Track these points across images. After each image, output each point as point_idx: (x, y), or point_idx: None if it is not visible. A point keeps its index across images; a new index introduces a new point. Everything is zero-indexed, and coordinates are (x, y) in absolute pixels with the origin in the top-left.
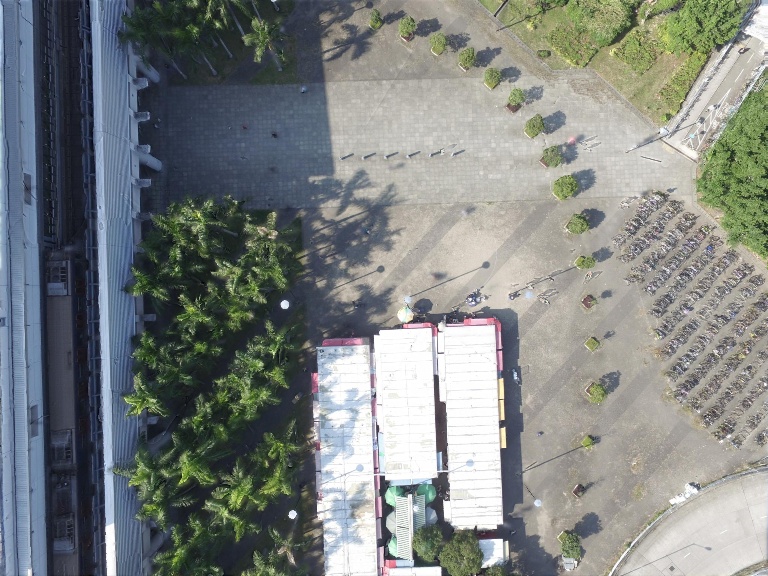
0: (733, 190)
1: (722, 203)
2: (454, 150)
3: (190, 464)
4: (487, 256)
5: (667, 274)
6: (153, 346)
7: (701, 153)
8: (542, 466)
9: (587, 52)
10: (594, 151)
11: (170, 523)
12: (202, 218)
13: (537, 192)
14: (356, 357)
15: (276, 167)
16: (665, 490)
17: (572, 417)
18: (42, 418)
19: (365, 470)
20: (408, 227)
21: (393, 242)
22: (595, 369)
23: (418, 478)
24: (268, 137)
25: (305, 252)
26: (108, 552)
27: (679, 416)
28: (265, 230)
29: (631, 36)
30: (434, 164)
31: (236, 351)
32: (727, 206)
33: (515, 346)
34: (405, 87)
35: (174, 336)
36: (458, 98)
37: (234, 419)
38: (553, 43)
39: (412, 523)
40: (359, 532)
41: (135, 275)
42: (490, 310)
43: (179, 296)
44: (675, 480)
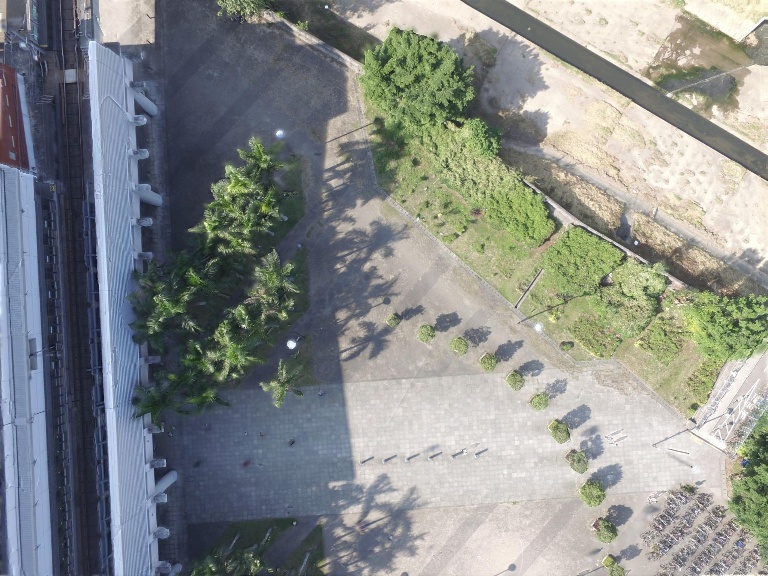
0: None
1: None
2: (477, 449)
3: None
4: (513, 558)
5: (697, 572)
6: None
7: (730, 446)
8: None
9: (611, 343)
10: (620, 445)
11: None
12: None
13: (563, 490)
14: None
15: (295, 473)
16: None
17: None
18: None
19: None
20: (431, 531)
21: (416, 547)
22: None
23: None
24: (286, 442)
25: (326, 560)
26: None
27: None
28: None
29: (656, 326)
30: (457, 465)
31: None
32: (760, 528)
33: None
34: (425, 385)
35: None
36: (480, 395)
37: None
38: (576, 335)
39: None
40: None
41: None
42: None
43: None
44: None
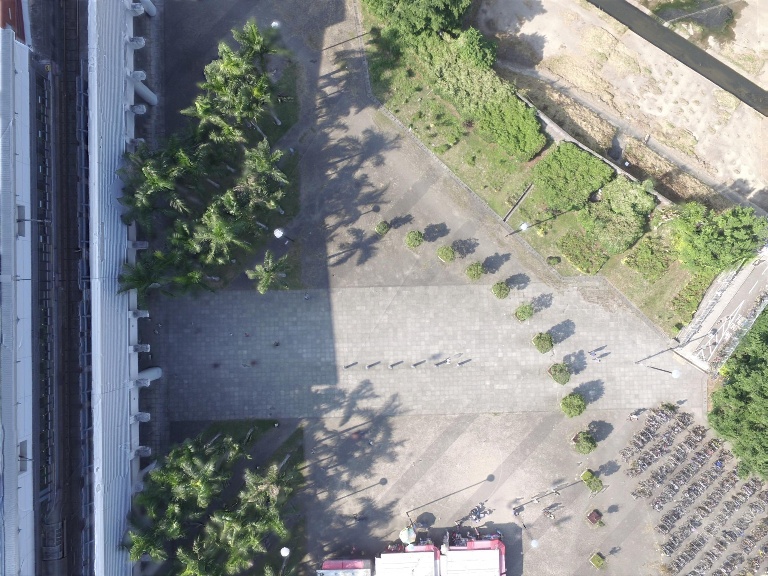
0: (746, 435)
1: (734, 437)
2: (460, 359)
3: None
4: (492, 469)
5: (675, 490)
6: None
7: (712, 366)
8: None
9: (598, 260)
10: (603, 361)
11: None
12: (201, 485)
13: (544, 403)
14: None
15: (278, 375)
16: None
17: None
18: None
19: None
20: (412, 438)
21: (396, 454)
22: None
23: None
24: (271, 344)
25: (306, 463)
26: None
27: None
28: (266, 486)
29: (643, 244)
30: (439, 374)
31: None
32: (739, 440)
33: (519, 561)
34: (411, 294)
35: None
36: (465, 306)
37: None
38: (563, 250)
39: None
40: None
41: None
42: (494, 524)
43: (177, 550)
44: None
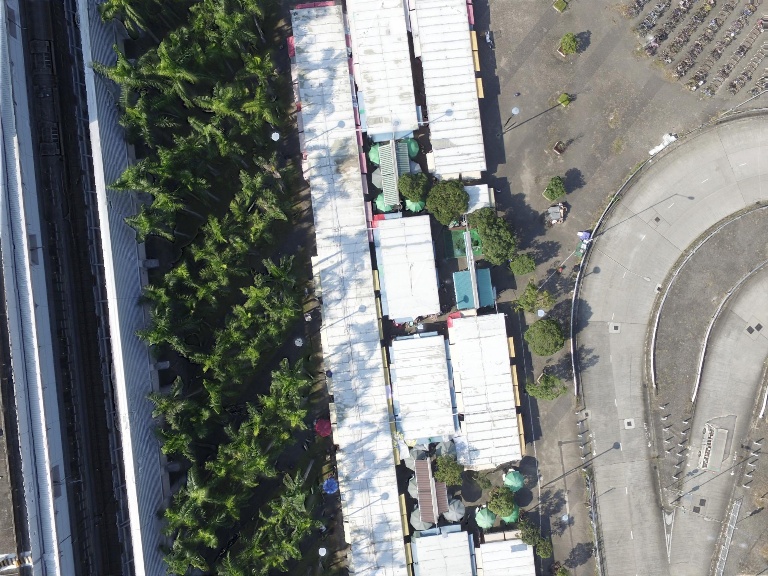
0: None
1: None
2: None
3: (168, 57)
4: None
5: None
6: None
7: None
8: (521, 126)
9: None
10: None
11: (154, 139)
12: None
13: None
14: (329, 17)
15: None
16: (644, 142)
17: (547, 77)
18: (20, 29)
19: (347, 126)
20: None
21: None
22: (565, 30)
23: (399, 131)
24: None
25: None
26: (93, 148)
27: (651, 70)
28: None
29: None
30: None
31: None
32: None
33: (486, 12)
34: None
35: None
36: None
37: (211, 50)
38: None
39: (396, 167)
40: (345, 186)
41: None
42: None
43: None
44: (653, 132)
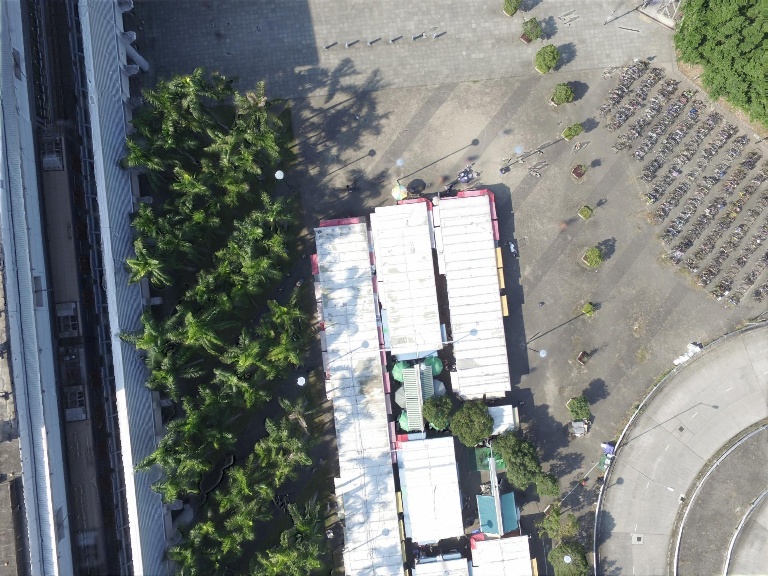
0: (710, 37)
1: (701, 56)
2: (436, 33)
3: (196, 325)
4: (476, 134)
5: (654, 139)
6: (151, 216)
7: (677, 19)
8: (545, 336)
9: None
10: (573, 25)
11: (180, 393)
12: (191, 83)
13: (520, 68)
14: (354, 235)
15: (262, 60)
16: (668, 351)
17: (571, 286)
18: (46, 292)
19: (371, 346)
20: (396, 110)
21: (382, 126)
22: (590, 237)
23: (424, 351)
24: (252, 32)
25: (296, 141)
26: (120, 417)
27: (676, 278)
28: (254, 97)
29: None
30: (417, 47)
31: (234, 220)
32: (706, 59)
33: (510, 220)
34: None
35: (172, 211)
36: None
37: (237, 292)
38: None
39: (421, 393)
40: (369, 408)
41: (129, 147)
42: (483, 186)
43: (174, 169)
44: (677, 341)
